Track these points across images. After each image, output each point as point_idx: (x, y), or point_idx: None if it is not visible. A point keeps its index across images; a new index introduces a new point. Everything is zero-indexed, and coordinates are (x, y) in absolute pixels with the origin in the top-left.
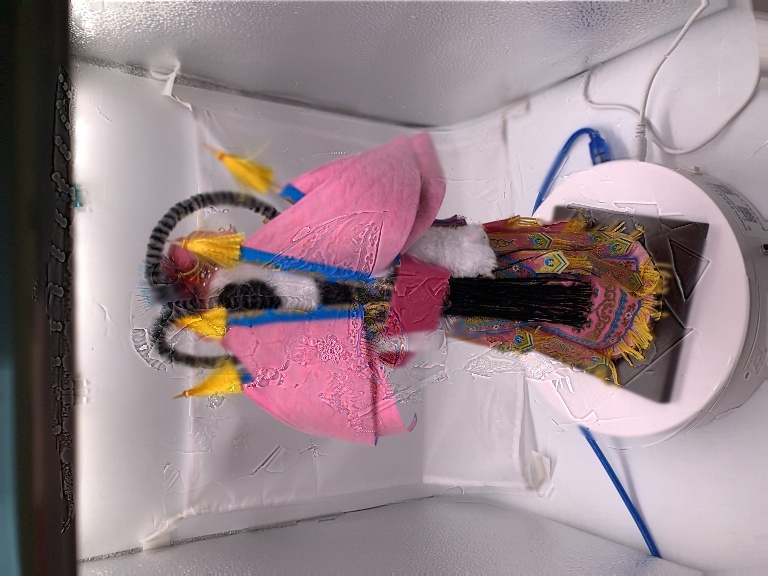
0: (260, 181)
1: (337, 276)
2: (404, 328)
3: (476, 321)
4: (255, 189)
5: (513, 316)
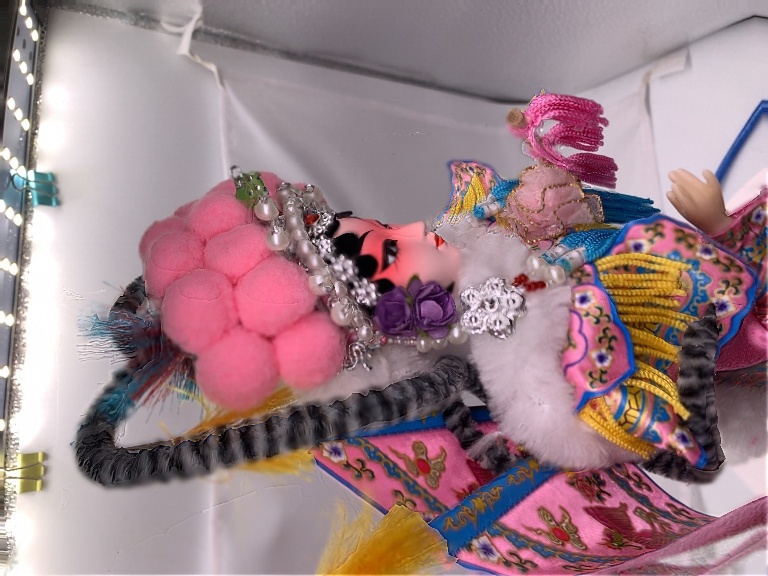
0: None
1: None
2: (445, 209)
3: None
4: None
5: None
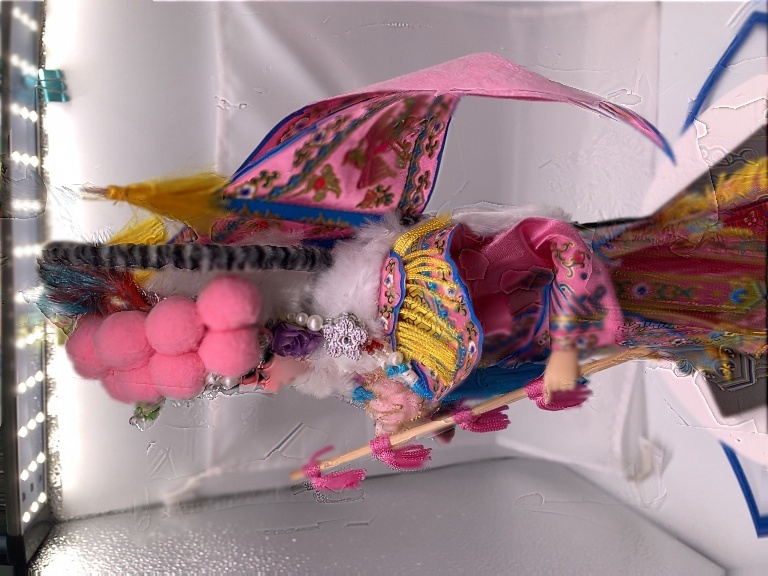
0: (289, 65)
1: (365, 209)
2: (477, 313)
3: (638, 330)
4: (282, 76)
5: (724, 323)
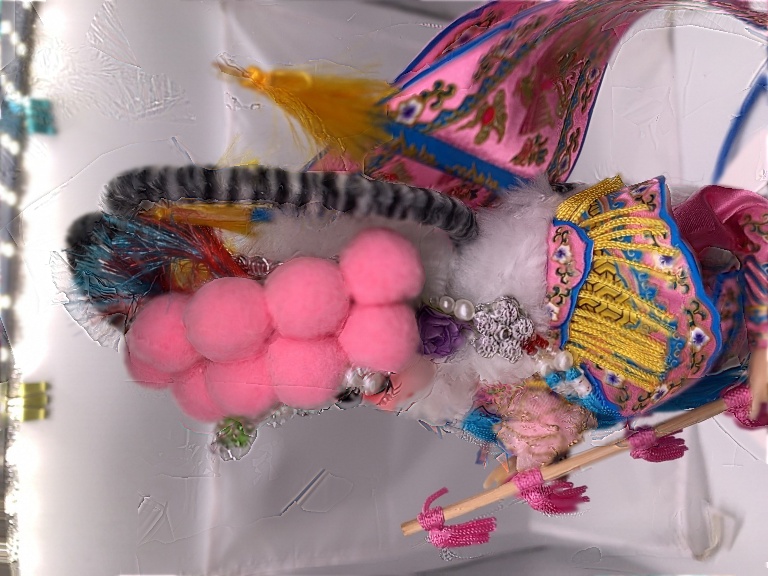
0: None
1: (516, 166)
2: (707, 288)
3: None
4: None
5: None
